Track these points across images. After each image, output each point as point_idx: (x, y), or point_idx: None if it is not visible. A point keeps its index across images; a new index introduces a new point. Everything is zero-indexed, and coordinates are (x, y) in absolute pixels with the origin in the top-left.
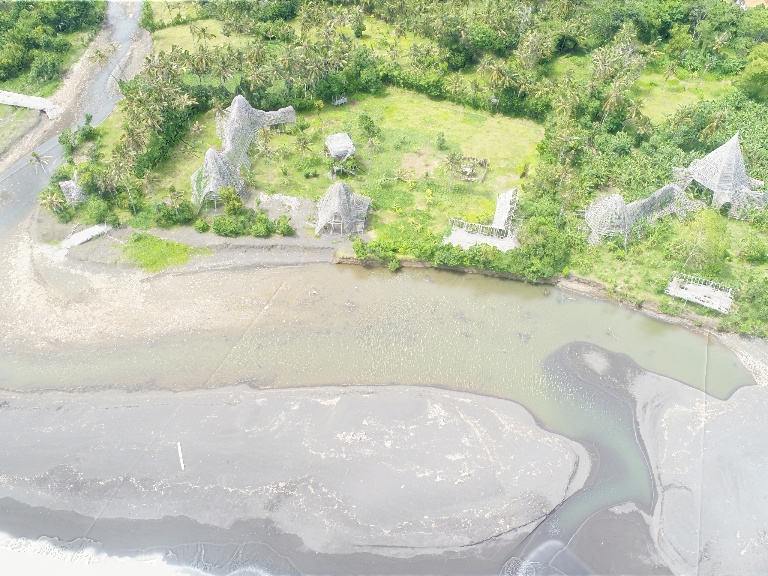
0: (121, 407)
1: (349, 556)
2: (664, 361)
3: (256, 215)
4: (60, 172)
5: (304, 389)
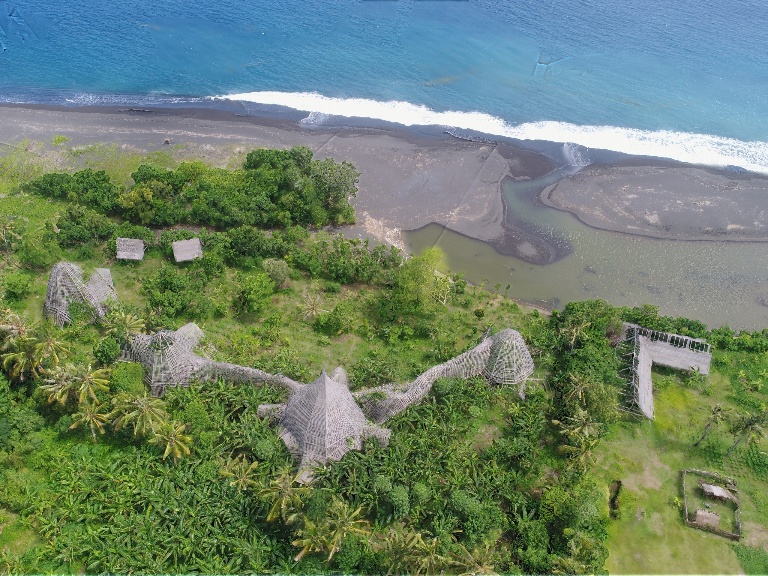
0: None
1: (677, 167)
2: (469, 249)
3: None
4: None
5: (758, 239)
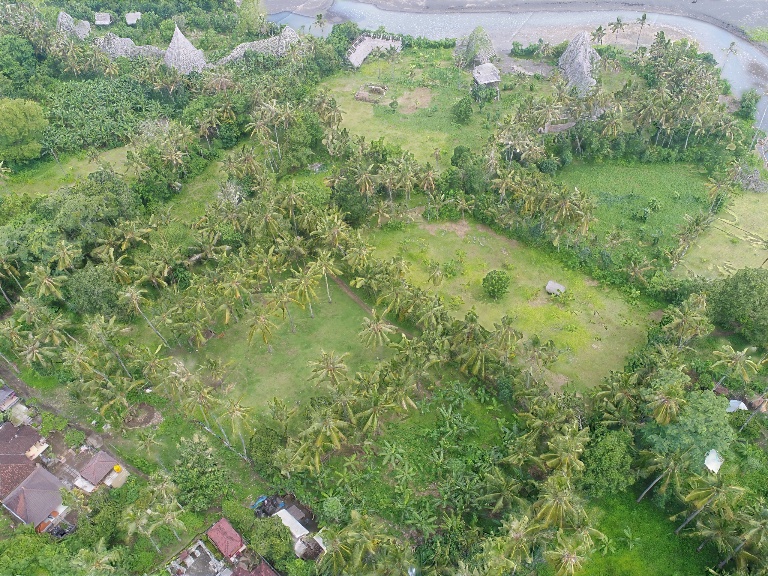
0: (567, 3)
1: None
2: None
3: (538, 44)
4: (708, 55)
5: (484, 11)
